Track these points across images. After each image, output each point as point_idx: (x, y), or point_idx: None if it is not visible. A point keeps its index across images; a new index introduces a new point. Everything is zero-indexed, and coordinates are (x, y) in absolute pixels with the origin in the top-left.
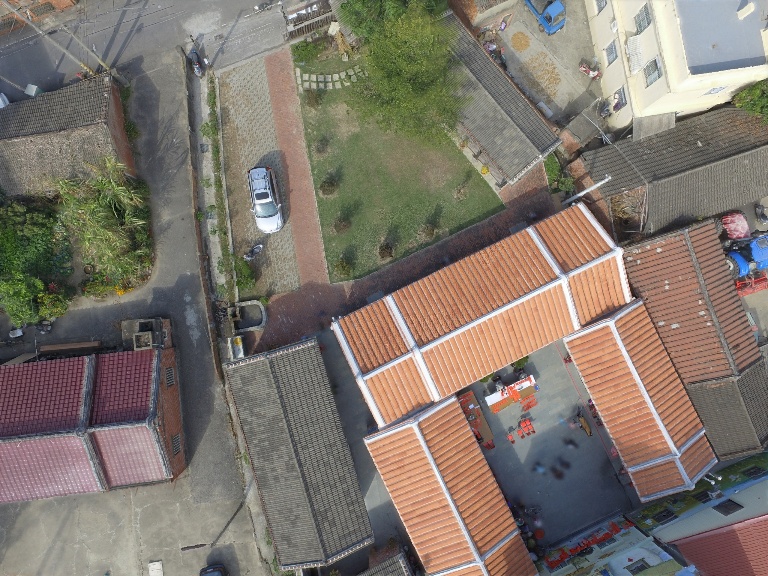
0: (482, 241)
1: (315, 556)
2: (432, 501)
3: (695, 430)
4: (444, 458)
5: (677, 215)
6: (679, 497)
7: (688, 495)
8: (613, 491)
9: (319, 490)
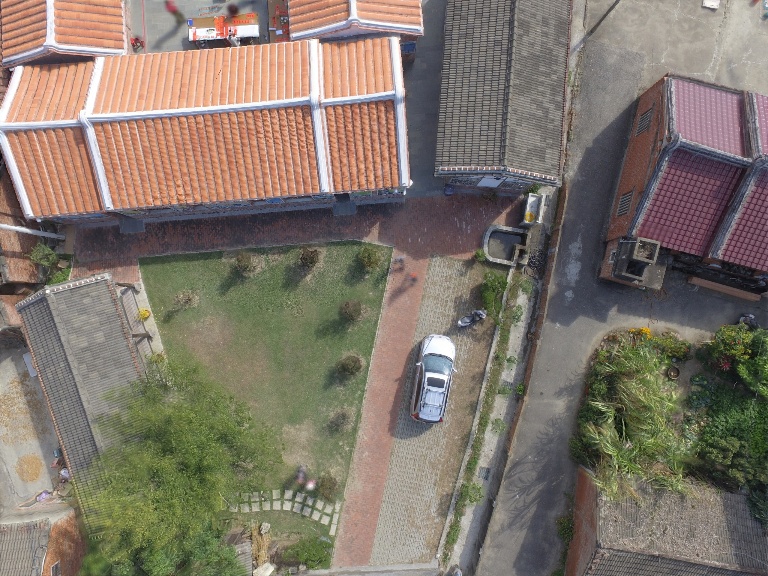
0: (186, 229)
1: None
2: None
3: None
4: None
5: None
6: None
7: None
8: None
9: None
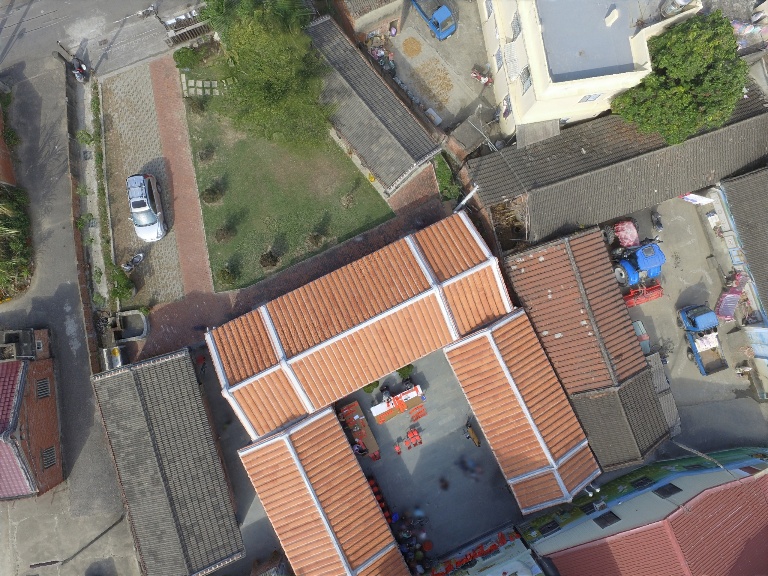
0: (371, 249)
1: (180, 572)
2: (305, 514)
3: (576, 441)
4: (317, 471)
5: (561, 223)
6: (568, 508)
7: (576, 506)
8: (504, 502)
9: (185, 504)
